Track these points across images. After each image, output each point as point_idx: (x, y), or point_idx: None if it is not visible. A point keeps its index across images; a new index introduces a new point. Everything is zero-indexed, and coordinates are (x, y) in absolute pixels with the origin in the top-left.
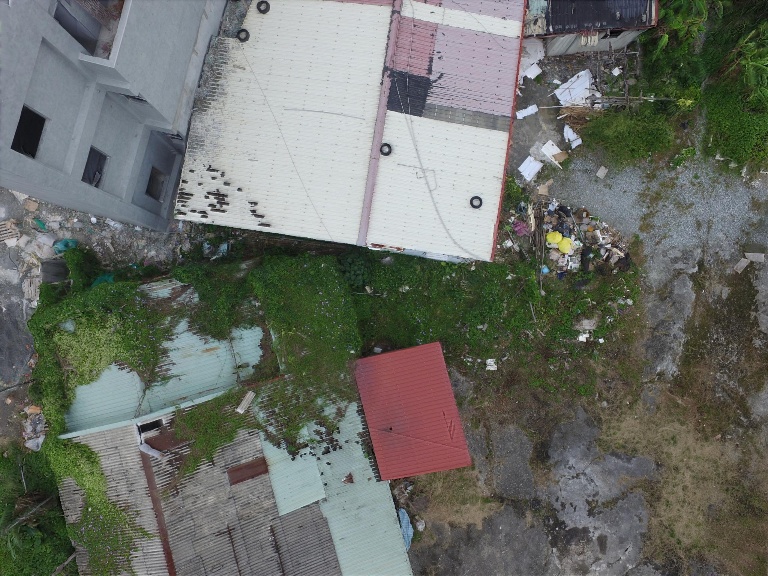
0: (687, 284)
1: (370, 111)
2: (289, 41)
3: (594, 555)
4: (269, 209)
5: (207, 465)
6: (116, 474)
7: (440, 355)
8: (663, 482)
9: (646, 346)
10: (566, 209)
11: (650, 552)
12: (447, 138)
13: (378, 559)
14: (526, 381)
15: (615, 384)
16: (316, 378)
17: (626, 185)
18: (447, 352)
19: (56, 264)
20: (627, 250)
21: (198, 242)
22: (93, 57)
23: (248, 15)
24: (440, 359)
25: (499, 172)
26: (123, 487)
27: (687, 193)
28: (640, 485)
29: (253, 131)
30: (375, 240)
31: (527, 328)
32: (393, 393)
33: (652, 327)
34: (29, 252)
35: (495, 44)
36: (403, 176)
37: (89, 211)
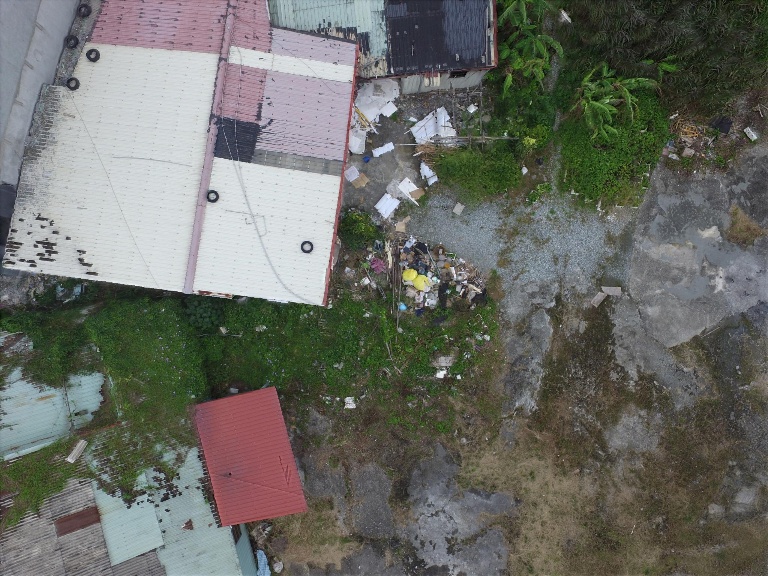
0: (544, 319)
1: (197, 158)
2: (119, 89)
3: None
4: (97, 257)
5: (32, 517)
6: None
7: (276, 400)
8: (522, 518)
9: (504, 381)
10: (423, 246)
11: None
12: (277, 183)
13: None
14: (384, 419)
15: (474, 420)
16: (155, 424)
17: (483, 221)
18: (305, 391)
19: None
20: (484, 286)
21: (52, 285)
22: None
23: (79, 63)
24: (276, 404)
25: (331, 216)
26: None
27: (544, 228)
28: (499, 521)
29: (82, 179)
30: (202, 287)
31: (384, 366)
32: (232, 438)
33: (510, 362)
34: None
35: (326, 89)
36: (231, 222)
37: None
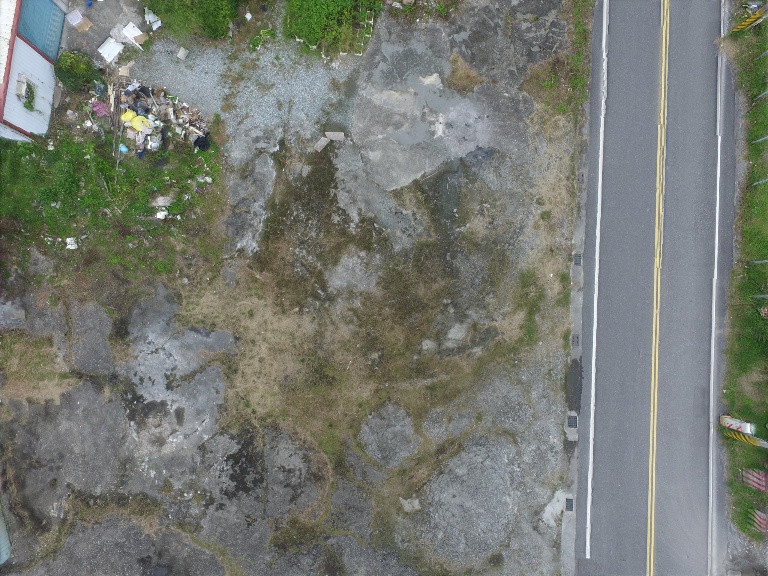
0: (268, 163)
1: None
2: None
3: (171, 427)
4: None
5: None
6: None
7: None
8: (240, 354)
9: (226, 223)
10: (147, 90)
11: (226, 422)
12: None
13: None
14: (105, 259)
15: (196, 261)
16: None
17: (208, 66)
18: (25, 231)
19: None
20: (208, 130)
21: None
22: None
23: None
24: None
25: (6, 32)
26: None
27: (268, 74)
28: (218, 358)
29: None
30: None
31: (104, 206)
32: None
33: (233, 205)
34: None
35: None
36: None
37: None
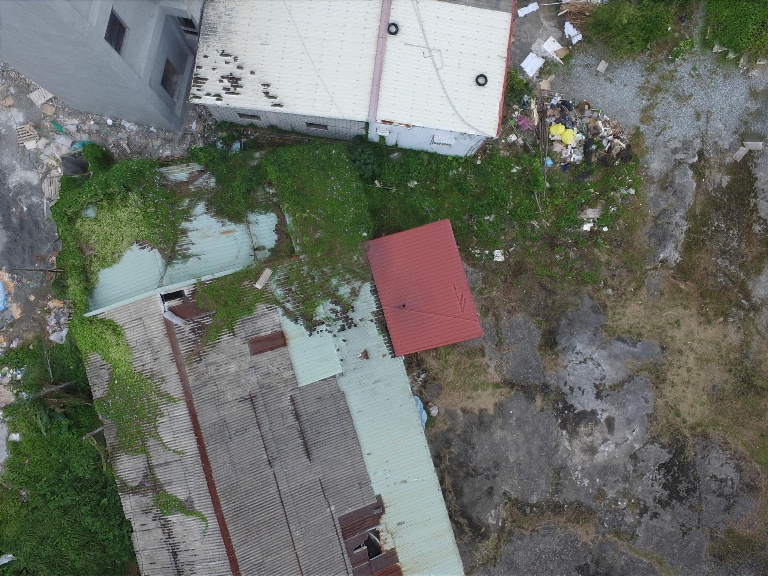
0: (688, 173)
1: None
2: None
3: (602, 436)
4: (281, 90)
5: (228, 335)
6: (141, 344)
7: (450, 231)
8: (668, 364)
9: (649, 234)
10: (568, 103)
11: (657, 432)
12: (452, 19)
13: (394, 431)
14: (533, 270)
15: (619, 272)
16: (330, 259)
17: (626, 79)
18: None
19: (75, 163)
20: (628, 142)
21: (211, 142)
22: None
23: None
24: (450, 235)
25: (503, 51)
26: (148, 356)
27: (686, 85)
28: (646, 368)
29: (264, 16)
30: (385, 117)
31: (533, 219)
32: (405, 271)
33: (654, 216)
34: (48, 154)
35: None
36: (410, 55)
37: (106, 105)
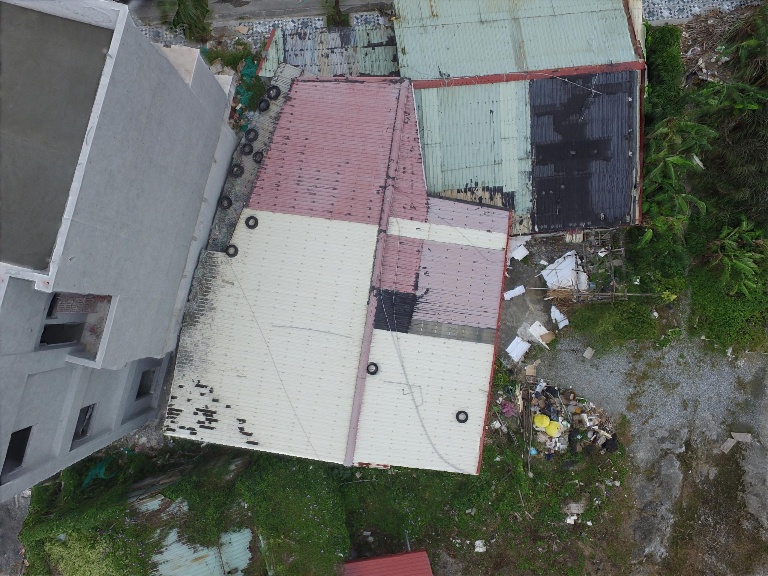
0: (674, 464)
1: (357, 330)
2: (277, 257)
3: None
4: (257, 427)
5: None
6: None
7: (427, 565)
8: None
9: (634, 527)
10: (553, 390)
11: None
12: (433, 353)
13: None
14: (515, 563)
15: (603, 565)
16: None
17: (613, 365)
18: (436, 534)
19: None
20: (614, 430)
21: None
22: (80, 359)
23: (237, 229)
24: (427, 569)
25: (485, 385)
26: None
27: (673, 373)
28: None
29: (241, 347)
30: (362, 459)
31: (515, 511)
32: None
33: (640, 508)
34: None
35: (480, 257)
36: (389, 393)
37: None
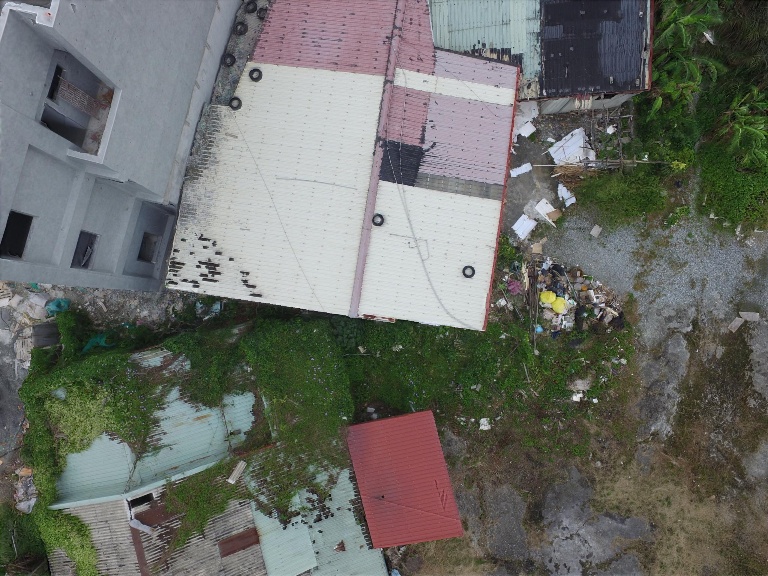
0: (681, 343)
1: (362, 181)
2: (281, 110)
3: None
4: (261, 279)
5: (198, 538)
6: (106, 548)
7: (432, 424)
8: (657, 543)
9: (640, 406)
10: (560, 268)
11: None
12: (440, 207)
13: None
14: (520, 441)
15: (609, 444)
16: (308, 445)
17: (620, 244)
18: (440, 412)
19: (48, 325)
20: (621, 309)
21: (191, 301)
22: (81, 153)
23: (240, 83)
24: (432, 428)
25: (492, 241)
26: (113, 561)
27: (681, 252)
28: (634, 546)
29: (245, 200)
30: (367, 311)
31: (521, 388)
32: (385, 461)
33: (646, 386)
34: (21, 312)
35: (488, 112)
36: (395, 246)
37: None
